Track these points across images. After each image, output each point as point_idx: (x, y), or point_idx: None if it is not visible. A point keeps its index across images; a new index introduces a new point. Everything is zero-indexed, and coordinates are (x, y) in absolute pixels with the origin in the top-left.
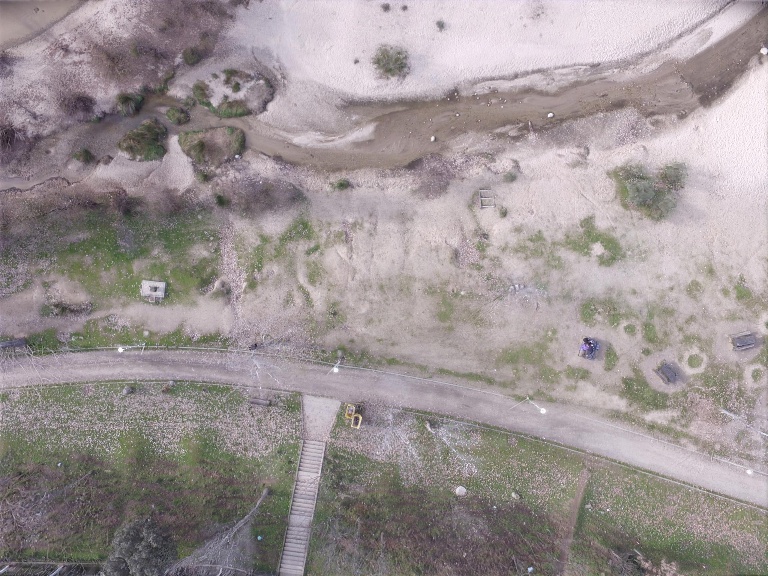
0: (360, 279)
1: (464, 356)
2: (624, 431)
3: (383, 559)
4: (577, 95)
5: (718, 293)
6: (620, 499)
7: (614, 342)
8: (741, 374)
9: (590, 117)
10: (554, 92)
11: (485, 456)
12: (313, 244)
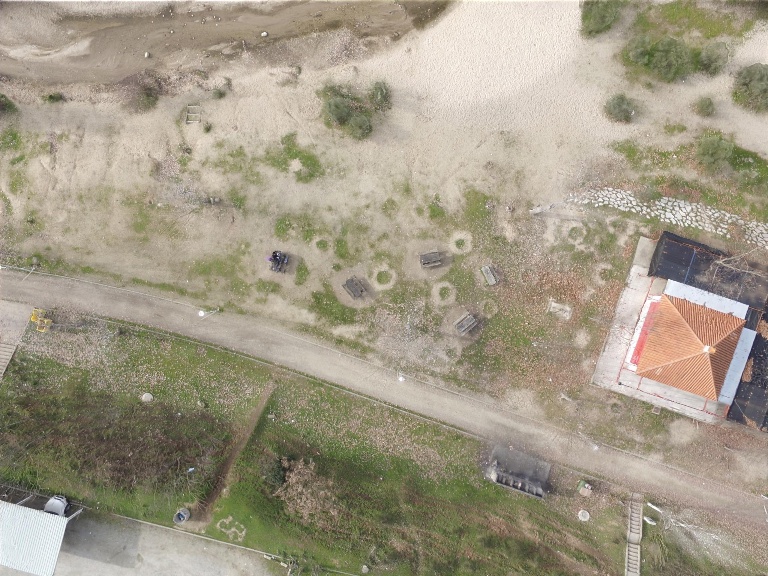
0: (60, 189)
1: (158, 267)
2: (312, 345)
3: (44, 453)
4: (291, 15)
5: (412, 212)
6: (305, 411)
7: (306, 257)
8: (429, 292)
9: (303, 37)
10: (268, 11)
11: (174, 365)
12: (18, 154)
